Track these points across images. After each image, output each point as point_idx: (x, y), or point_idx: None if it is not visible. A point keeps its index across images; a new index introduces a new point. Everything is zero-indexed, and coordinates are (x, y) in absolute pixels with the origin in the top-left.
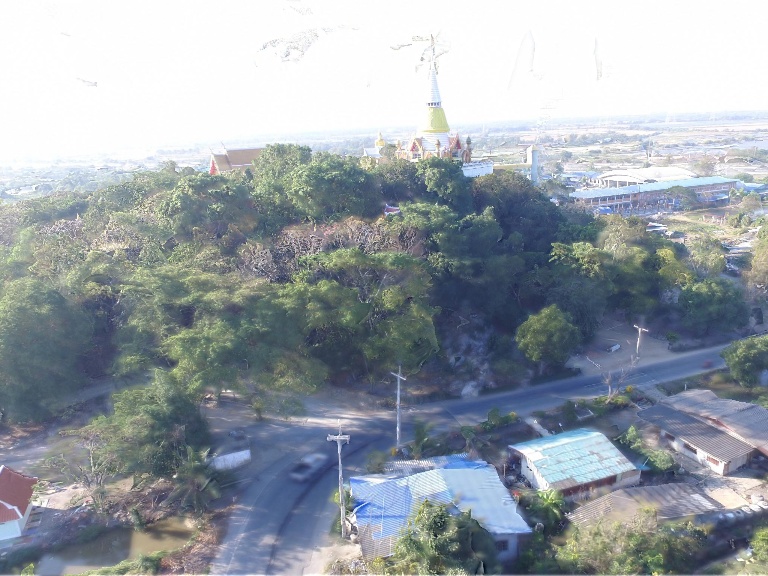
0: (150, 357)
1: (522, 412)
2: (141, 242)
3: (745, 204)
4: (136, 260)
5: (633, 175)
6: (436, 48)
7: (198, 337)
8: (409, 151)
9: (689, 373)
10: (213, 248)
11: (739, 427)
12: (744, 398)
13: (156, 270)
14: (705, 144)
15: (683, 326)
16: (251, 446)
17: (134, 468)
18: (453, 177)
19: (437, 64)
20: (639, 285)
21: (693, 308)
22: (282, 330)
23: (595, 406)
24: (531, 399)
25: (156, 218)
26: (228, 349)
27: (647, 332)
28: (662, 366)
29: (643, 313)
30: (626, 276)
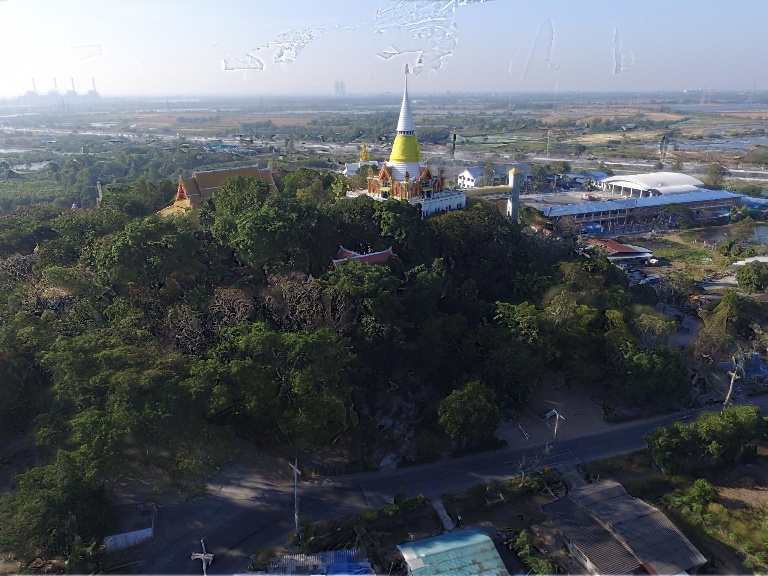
0: (62, 430)
1: (433, 493)
2: (71, 301)
3: (738, 230)
4: (66, 319)
5: (637, 182)
6: (435, 50)
7: (100, 421)
8: (379, 179)
9: (615, 452)
10: (141, 310)
11: (632, 538)
12: (661, 488)
13: (75, 340)
14: (731, 136)
15: (622, 394)
16: (158, 519)
17: (20, 560)
18: (408, 222)
19: (439, 63)
20: (581, 349)
21: (632, 378)
22: (185, 415)
23: (508, 489)
24: (447, 476)
25: (90, 274)
26: (127, 436)
27: (589, 394)
28: (591, 441)
29: (581, 380)
30: (570, 339)
